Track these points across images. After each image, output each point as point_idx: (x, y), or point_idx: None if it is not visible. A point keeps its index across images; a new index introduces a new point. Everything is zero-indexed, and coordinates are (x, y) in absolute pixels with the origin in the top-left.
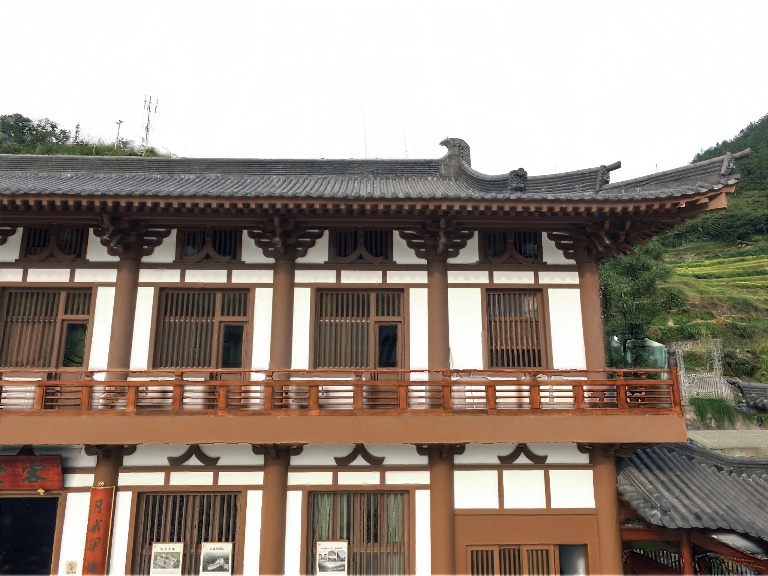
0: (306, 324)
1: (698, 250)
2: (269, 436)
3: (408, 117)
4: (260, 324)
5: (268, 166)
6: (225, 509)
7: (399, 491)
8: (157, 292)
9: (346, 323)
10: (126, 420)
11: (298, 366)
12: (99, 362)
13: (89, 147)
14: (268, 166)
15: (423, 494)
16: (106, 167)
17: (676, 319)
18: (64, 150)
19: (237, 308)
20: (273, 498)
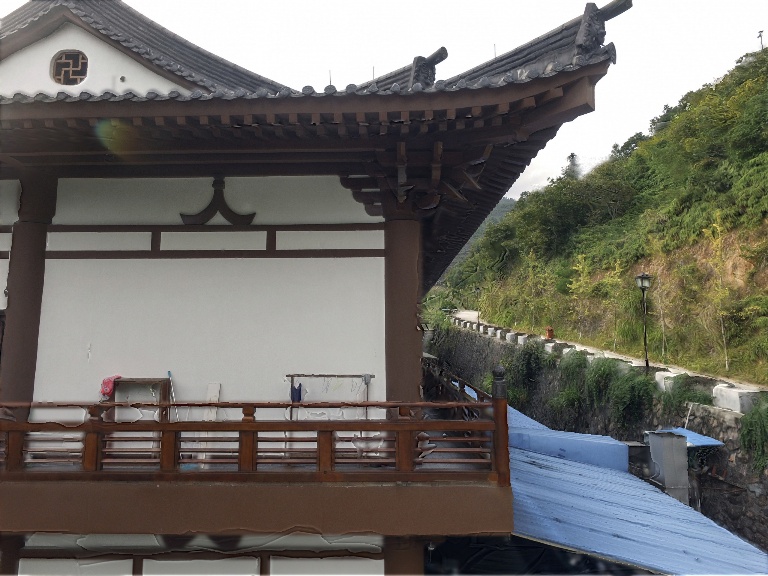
0: None
1: None
2: None
3: None
4: None
5: None
6: None
7: None
8: None
9: None
10: None
11: None
12: None
13: (692, 97)
14: None
15: None
16: None
17: None
18: None
19: None
20: None
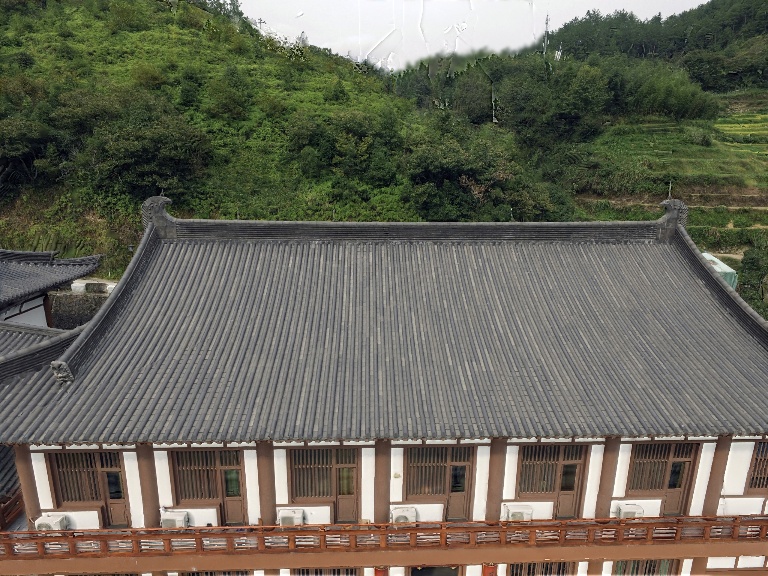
0: (626, 467)
1: (751, 99)
2: (621, 556)
3: None
4: (593, 468)
5: (499, 231)
6: (561, 569)
7: (672, 559)
8: (521, 449)
9: (650, 462)
10: (531, 550)
11: (618, 493)
12: (482, 494)
13: (116, 7)
14: (499, 231)
15: (688, 561)
16: (350, 234)
17: (735, 219)
18: (77, 1)
19: (574, 455)
20: (597, 568)
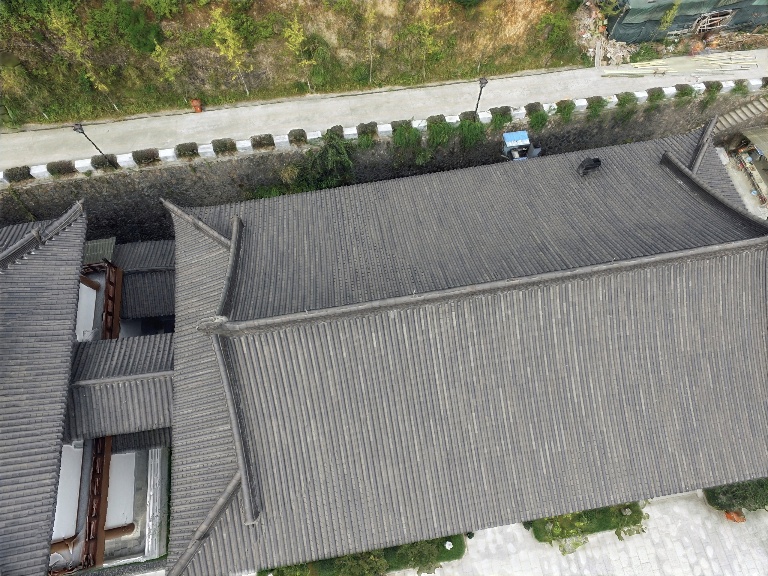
0: None
1: None
2: None
3: None
4: None
5: None
6: None
7: None
8: None
9: None
10: None
11: None
12: None
13: None
14: None
15: None
16: None
17: None
18: None
19: None
20: None
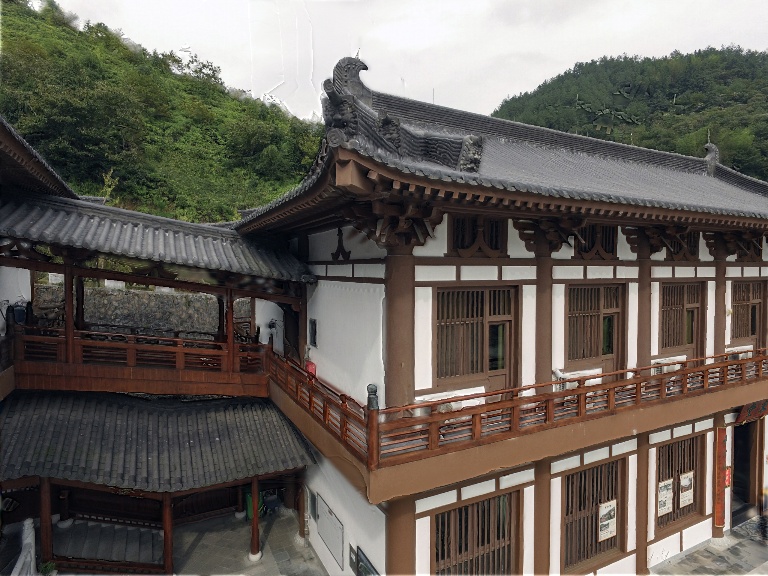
0: None
1: None
2: None
3: (355, 29)
4: None
5: (627, 152)
6: None
7: None
8: None
9: None
10: None
11: None
12: None
13: None
14: (627, 152)
15: None
16: (530, 136)
17: None
18: None
19: None
20: None
